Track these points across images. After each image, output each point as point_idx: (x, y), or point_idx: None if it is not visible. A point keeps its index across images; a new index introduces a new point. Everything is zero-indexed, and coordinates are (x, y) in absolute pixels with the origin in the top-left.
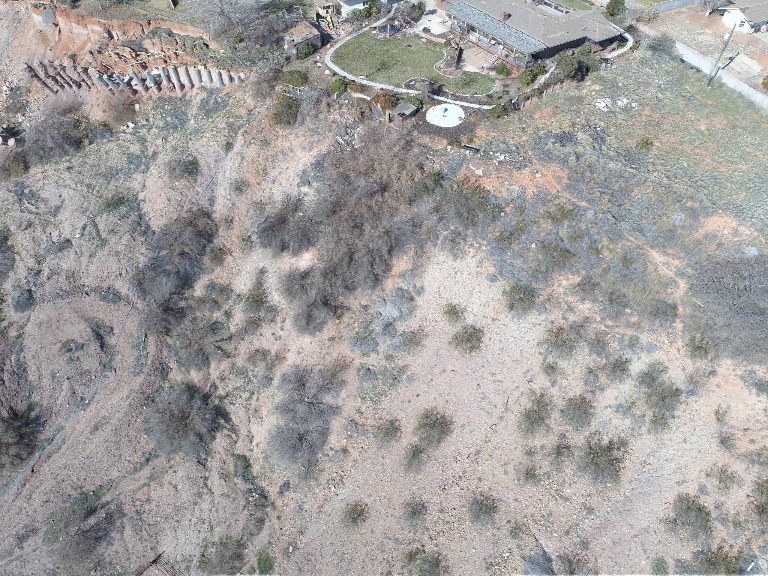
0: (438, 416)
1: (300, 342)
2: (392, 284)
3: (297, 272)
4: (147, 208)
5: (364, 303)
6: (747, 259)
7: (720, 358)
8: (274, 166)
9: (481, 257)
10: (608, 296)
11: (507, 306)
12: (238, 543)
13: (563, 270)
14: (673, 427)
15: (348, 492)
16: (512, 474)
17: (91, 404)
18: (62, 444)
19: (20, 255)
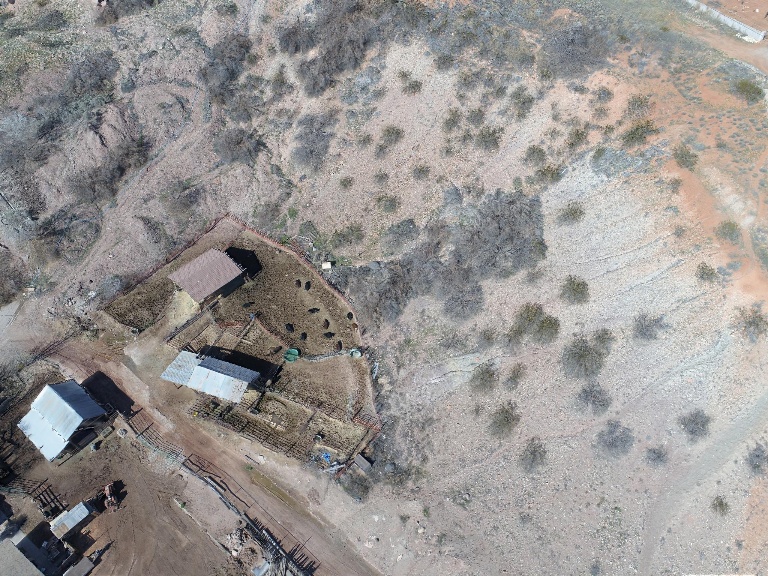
0: (395, 129)
1: (309, 102)
2: (366, 65)
3: (306, 63)
4: (204, 35)
5: (349, 77)
6: (575, 27)
7: (556, 79)
8: (288, 5)
9: (421, 43)
10: (496, 56)
11: (436, 67)
12: (276, 204)
13: (470, 45)
14: (529, 117)
15: (341, 174)
16: (438, 153)
17: (179, 137)
18: (164, 157)
19: (123, 62)
